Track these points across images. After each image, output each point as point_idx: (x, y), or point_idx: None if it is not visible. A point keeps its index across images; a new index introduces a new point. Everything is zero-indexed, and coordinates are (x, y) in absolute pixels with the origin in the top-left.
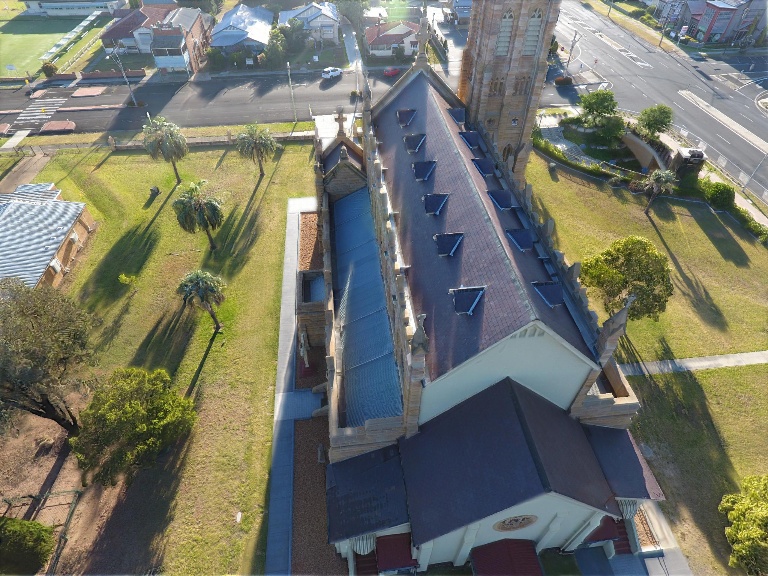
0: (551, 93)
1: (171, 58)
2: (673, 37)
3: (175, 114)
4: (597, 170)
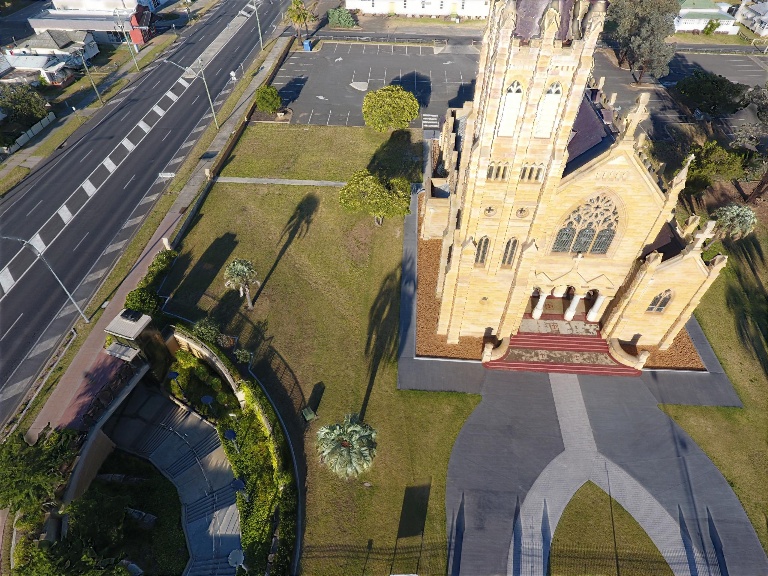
0: None
1: None
2: None
3: None
4: None
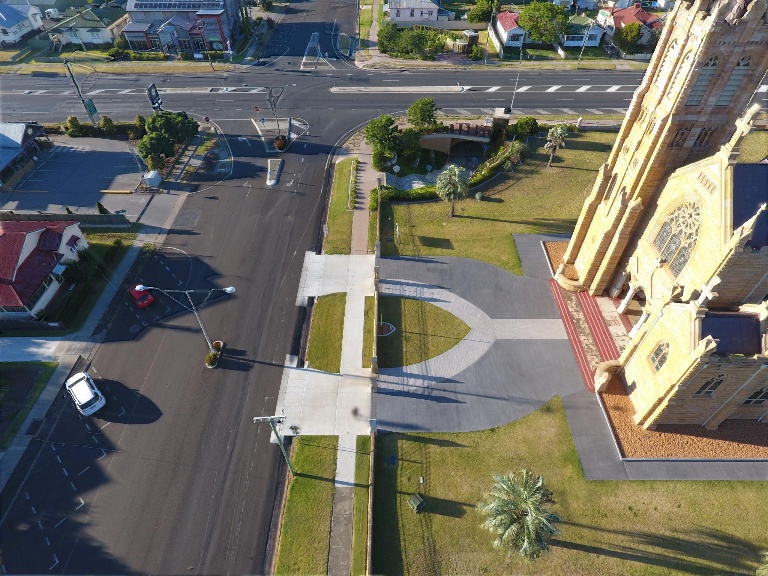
0: (299, 159)
1: None
2: (203, 58)
3: None
4: (491, 171)
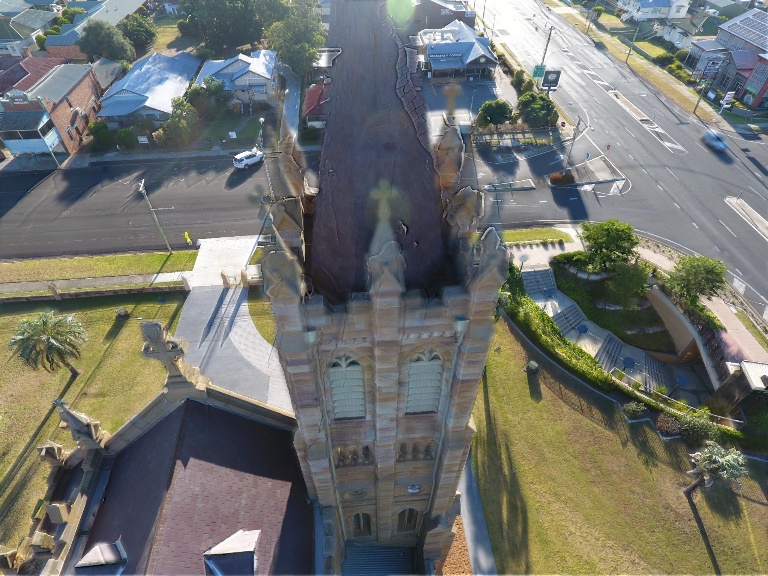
0: (543, 199)
1: (27, 142)
2: (712, 99)
3: (7, 234)
4: (604, 382)
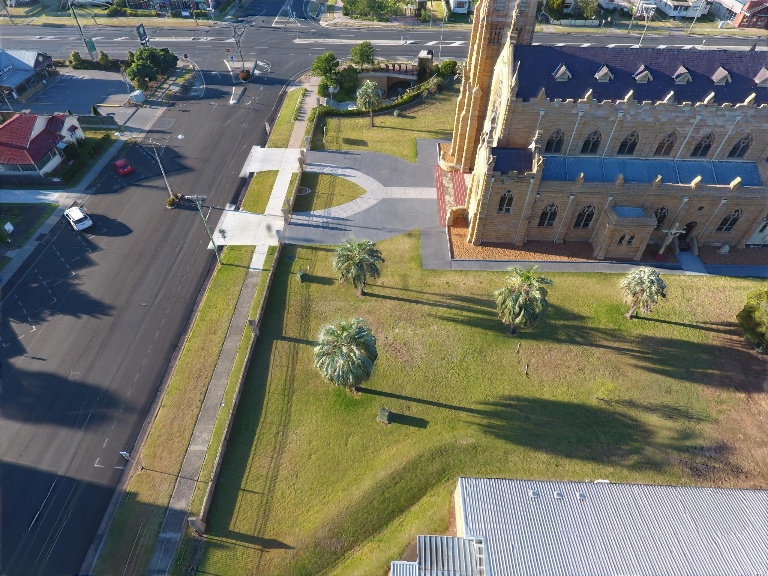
0: (259, 87)
1: None
2: (189, 15)
3: (83, 437)
4: (411, 97)
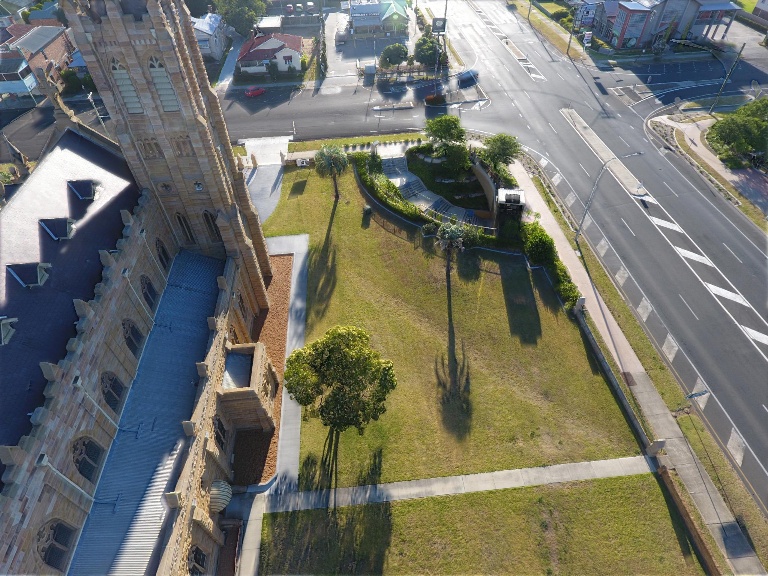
0: (417, 114)
1: (10, 83)
2: None
3: None
4: (413, 214)
